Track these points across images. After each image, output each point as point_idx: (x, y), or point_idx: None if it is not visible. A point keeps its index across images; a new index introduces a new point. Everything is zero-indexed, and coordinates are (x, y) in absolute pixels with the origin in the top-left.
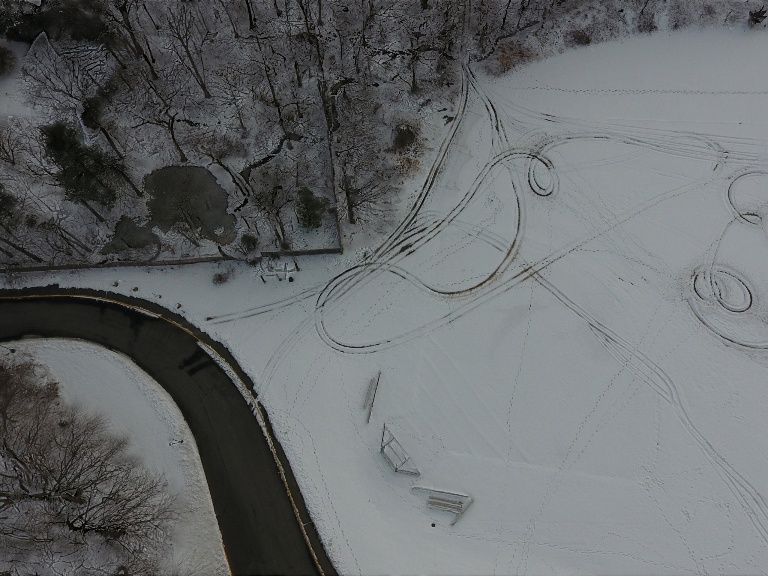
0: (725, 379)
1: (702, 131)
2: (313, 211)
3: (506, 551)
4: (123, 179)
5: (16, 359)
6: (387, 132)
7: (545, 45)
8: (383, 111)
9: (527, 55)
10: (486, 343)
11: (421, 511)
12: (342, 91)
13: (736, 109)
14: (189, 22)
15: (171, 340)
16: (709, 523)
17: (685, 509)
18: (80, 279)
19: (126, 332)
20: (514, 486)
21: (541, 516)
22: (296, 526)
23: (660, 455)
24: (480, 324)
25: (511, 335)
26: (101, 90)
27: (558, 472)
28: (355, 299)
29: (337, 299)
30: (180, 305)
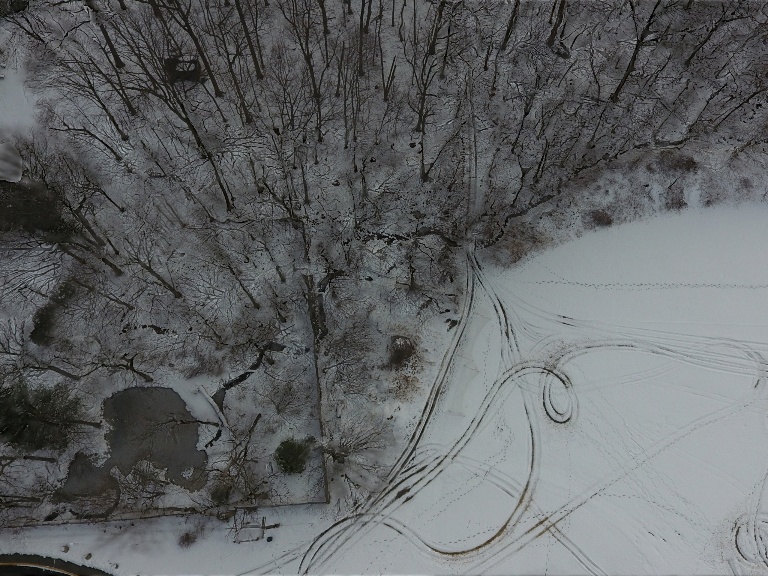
0: None
1: (740, 337)
2: (295, 460)
3: None
4: (75, 424)
5: None
6: (382, 342)
7: (561, 227)
8: (377, 316)
9: (540, 240)
10: None
11: None
12: (331, 288)
13: None
14: (150, 247)
15: None
16: None
17: None
18: (25, 542)
19: None
20: None
21: None
22: None
23: None
24: None
25: None
26: (55, 297)
27: None
28: (343, 563)
29: (323, 564)
30: None
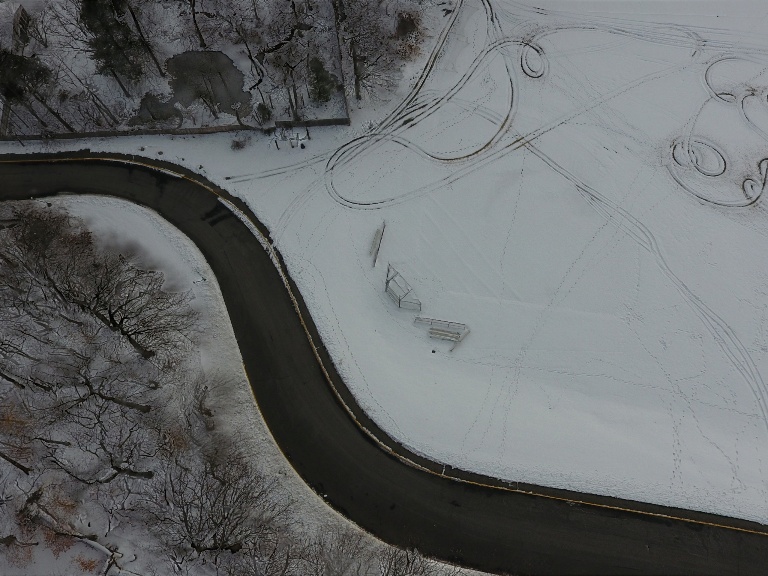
0: (700, 232)
1: (682, 23)
2: (323, 83)
3: (499, 373)
4: (148, 54)
5: (52, 212)
6: (390, 22)
7: None
8: (386, 4)
9: None
10: (482, 201)
11: (422, 340)
12: None
13: (714, 4)
14: None
15: (194, 196)
16: (684, 351)
17: (662, 339)
18: (109, 145)
19: (152, 190)
20: (507, 320)
21: (531, 345)
22: (309, 349)
23: (640, 295)
24: (476, 185)
25: (505, 195)
26: None
27: (547, 308)
28: (361, 164)
29: (345, 164)
30: (201, 166)
